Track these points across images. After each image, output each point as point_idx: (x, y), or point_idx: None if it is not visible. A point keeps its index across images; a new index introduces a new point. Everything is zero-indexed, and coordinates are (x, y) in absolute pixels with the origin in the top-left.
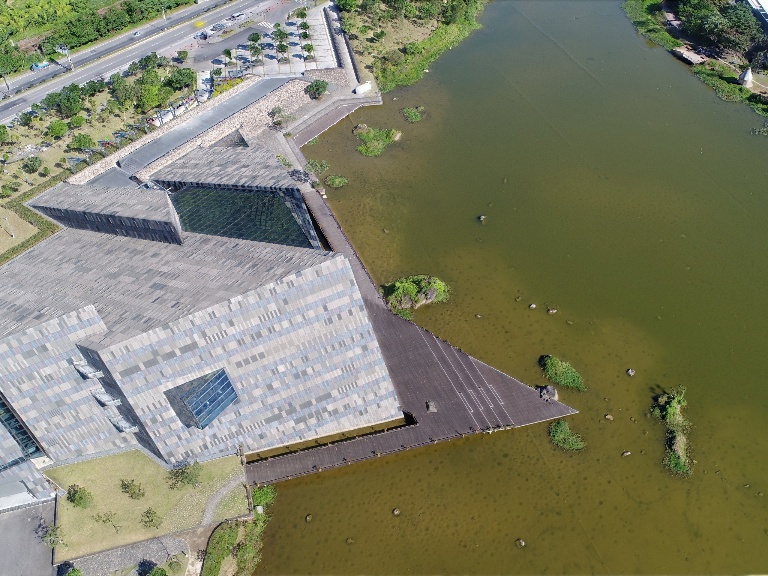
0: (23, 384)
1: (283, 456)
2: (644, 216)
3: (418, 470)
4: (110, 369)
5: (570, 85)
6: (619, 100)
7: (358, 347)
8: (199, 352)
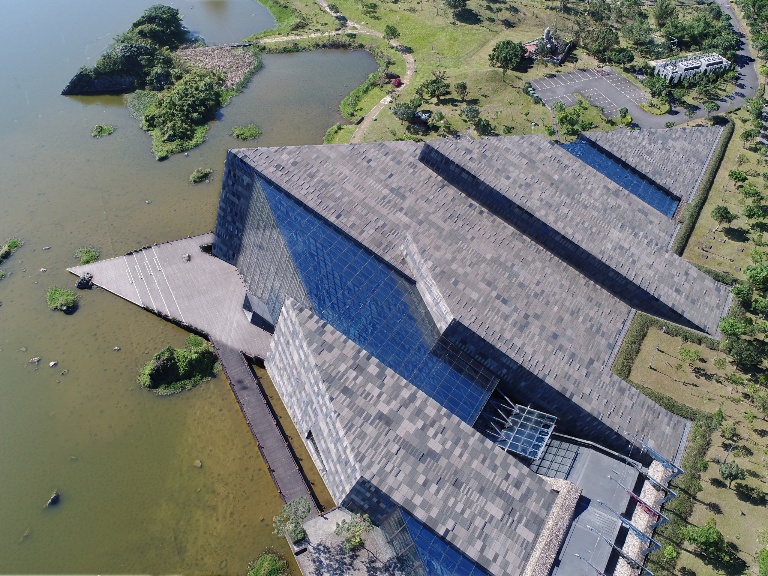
0: None
1: None
2: None
3: (206, 231)
4: None
5: None
6: None
7: None
8: None
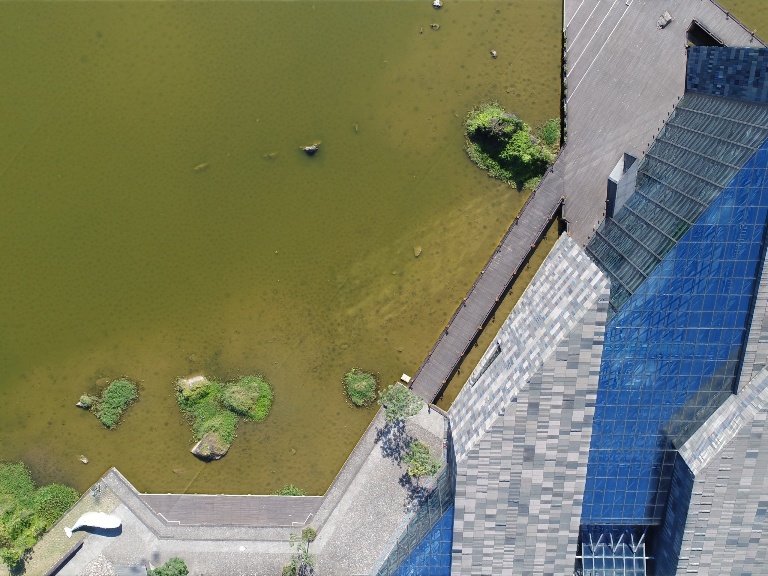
0: None
1: None
2: None
3: None
4: None
5: None
6: None
7: None
8: None
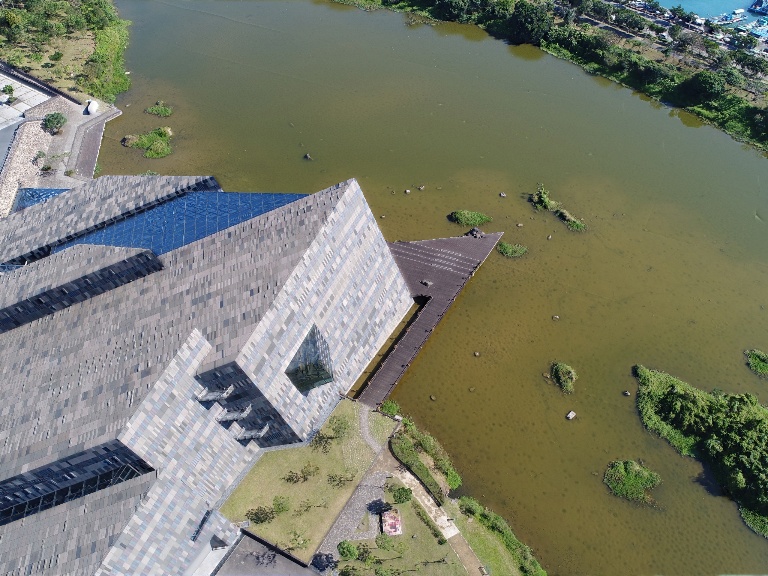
0: (165, 447)
1: (375, 376)
2: (406, 104)
3: (460, 324)
4: (247, 373)
5: (257, 40)
6: (303, 37)
7: (379, 257)
8: (296, 319)
